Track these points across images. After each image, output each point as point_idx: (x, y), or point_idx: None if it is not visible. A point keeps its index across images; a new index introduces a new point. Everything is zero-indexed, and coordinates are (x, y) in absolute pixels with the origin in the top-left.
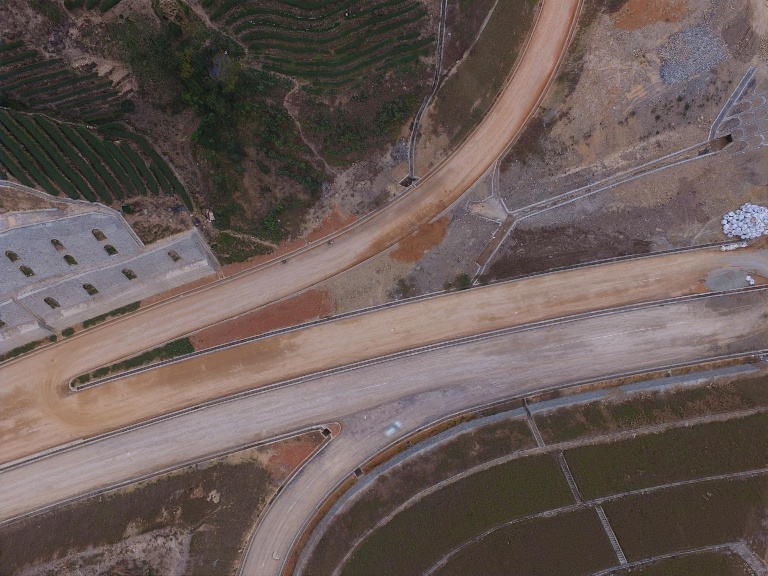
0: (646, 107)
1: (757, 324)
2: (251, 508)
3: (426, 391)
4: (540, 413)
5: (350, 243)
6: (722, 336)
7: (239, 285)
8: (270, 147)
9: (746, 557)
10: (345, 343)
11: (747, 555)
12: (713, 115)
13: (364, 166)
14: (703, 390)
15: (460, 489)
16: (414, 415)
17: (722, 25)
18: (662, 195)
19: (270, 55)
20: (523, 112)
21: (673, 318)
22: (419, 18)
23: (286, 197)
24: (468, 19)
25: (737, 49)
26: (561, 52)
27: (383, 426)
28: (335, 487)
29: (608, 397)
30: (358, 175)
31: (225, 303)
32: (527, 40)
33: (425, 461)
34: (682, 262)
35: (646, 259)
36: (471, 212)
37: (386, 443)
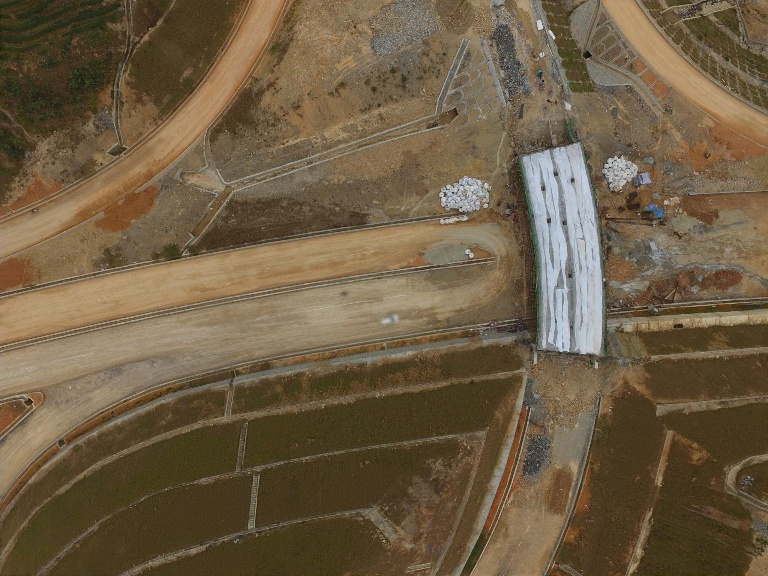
0: (358, 78)
1: (478, 298)
2: None
3: (133, 361)
4: (242, 384)
5: (55, 212)
6: (441, 310)
7: None
8: None
9: (378, 523)
10: (50, 312)
11: (379, 521)
12: (437, 88)
13: (66, 134)
14: (410, 362)
15: (137, 457)
16: (121, 385)
17: None
18: (385, 168)
19: None
20: (236, 82)
21: (391, 291)
22: None
23: None
24: None
25: (449, 21)
26: (276, 23)
27: (88, 396)
28: (37, 457)
29: (313, 369)
30: (60, 143)
31: None
32: (244, 10)
33: (119, 431)
34: (401, 235)
35: (363, 231)
36: (187, 183)
37: (91, 413)
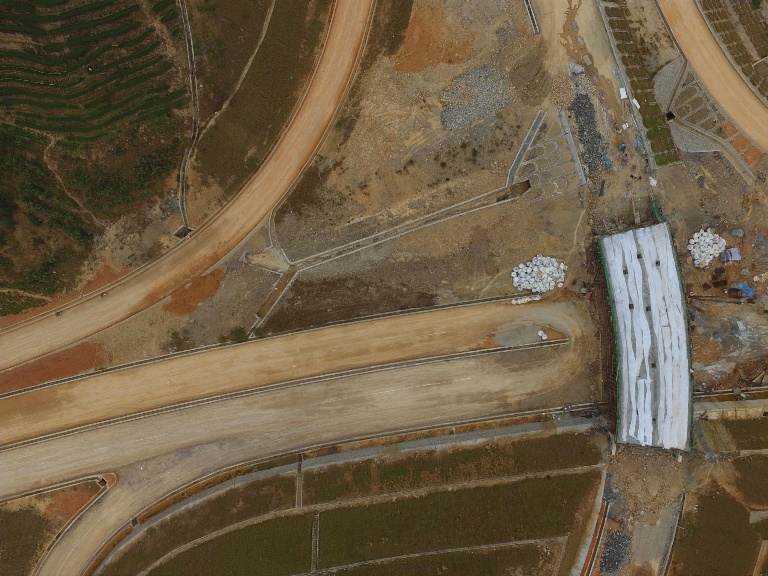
0: (427, 155)
1: (550, 381)
2: (28, 554)
3: (202, 444)
4: (310, 470)
5: (124, 295)
6: (512, 393)
7: (15, 336)
8: (37, 200)
9: None
10: (121, 395)
11: None
12: (509, 160)
13: (133, 218)
14: (481, 450)
15: (211, 548)
16: (190, 467)
17: (511, 65)
18: (454, 244)
19: (22, 110)
20: (301, 160)
21: (459, 373)
22: (165, 71)
23: (59, 249)
24: (222, 69)
25: (524, 92)
26: (341, 96)
27: (159, 477)
28: (112, 536)
29: (381, 455)
30: (127, 228)
31: (2, 354)
32: (308, 84)
33: (191, 515)
34: (470, 315)
35: (431, 312)
36: (252, 263)
37: (162, 494)
